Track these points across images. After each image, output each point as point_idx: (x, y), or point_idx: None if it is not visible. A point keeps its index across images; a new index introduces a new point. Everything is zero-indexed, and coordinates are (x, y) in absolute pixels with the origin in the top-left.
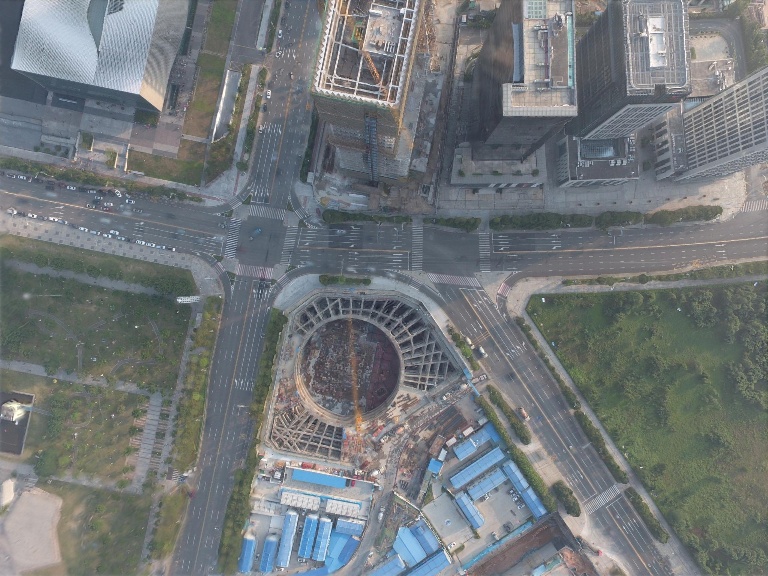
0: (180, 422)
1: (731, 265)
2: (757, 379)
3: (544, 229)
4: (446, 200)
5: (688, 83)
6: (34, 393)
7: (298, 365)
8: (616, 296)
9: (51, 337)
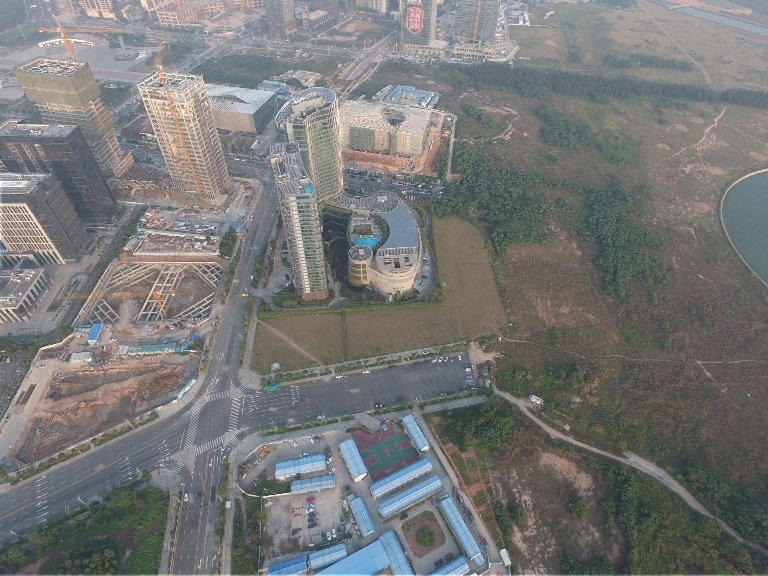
0: None
1: None
2: None
3: None
4: None
5: None
6: None
7: None
8: None
9: None
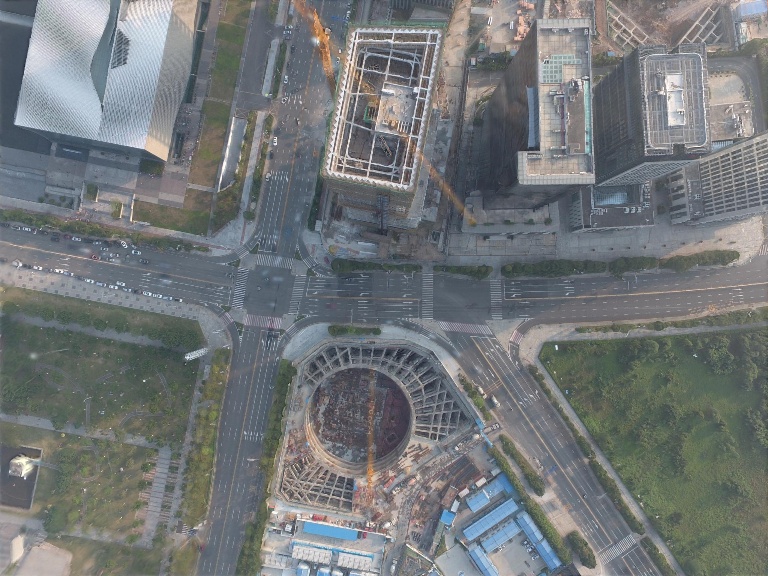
0: (190, 477)
1: (748, 310)
2: None
3: (557, 276)
4: (456, 247)
5: (708, 142)
6: (42, 447)
7: (308, 413)
8: (631, 343)
9: (58, 391)
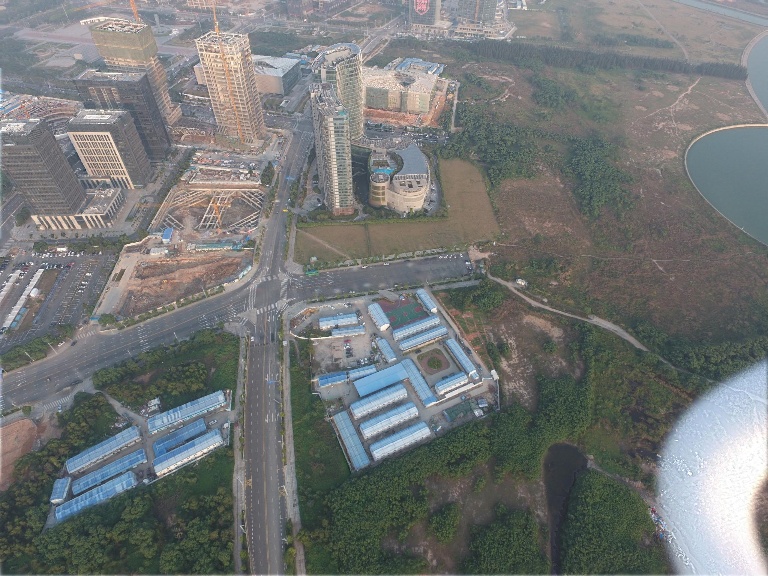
0: None
1: None
2: None
3: None
4: None
5: None
6: None
7: None
8: None
9: None
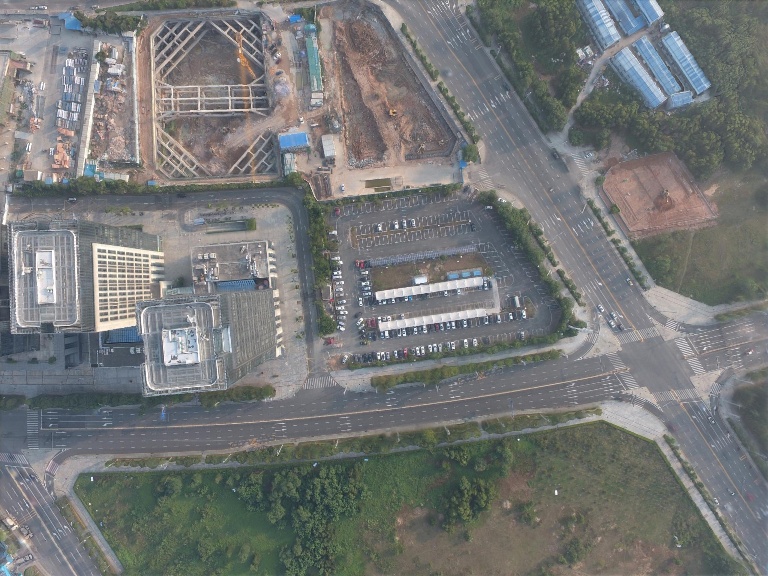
0: None
1: (284, 447)
2: (307, 566)
3: None
4: None
5: (79, 320)
6: None
7: None
8: (162, 478)
9: None
